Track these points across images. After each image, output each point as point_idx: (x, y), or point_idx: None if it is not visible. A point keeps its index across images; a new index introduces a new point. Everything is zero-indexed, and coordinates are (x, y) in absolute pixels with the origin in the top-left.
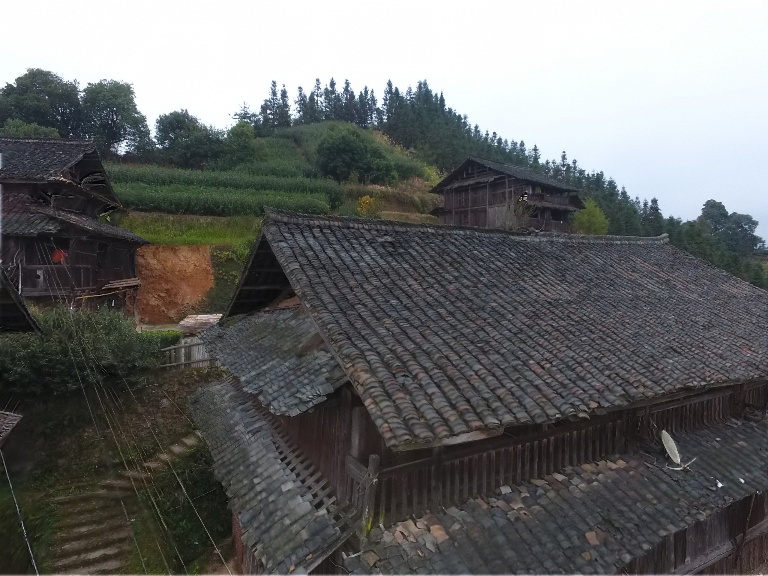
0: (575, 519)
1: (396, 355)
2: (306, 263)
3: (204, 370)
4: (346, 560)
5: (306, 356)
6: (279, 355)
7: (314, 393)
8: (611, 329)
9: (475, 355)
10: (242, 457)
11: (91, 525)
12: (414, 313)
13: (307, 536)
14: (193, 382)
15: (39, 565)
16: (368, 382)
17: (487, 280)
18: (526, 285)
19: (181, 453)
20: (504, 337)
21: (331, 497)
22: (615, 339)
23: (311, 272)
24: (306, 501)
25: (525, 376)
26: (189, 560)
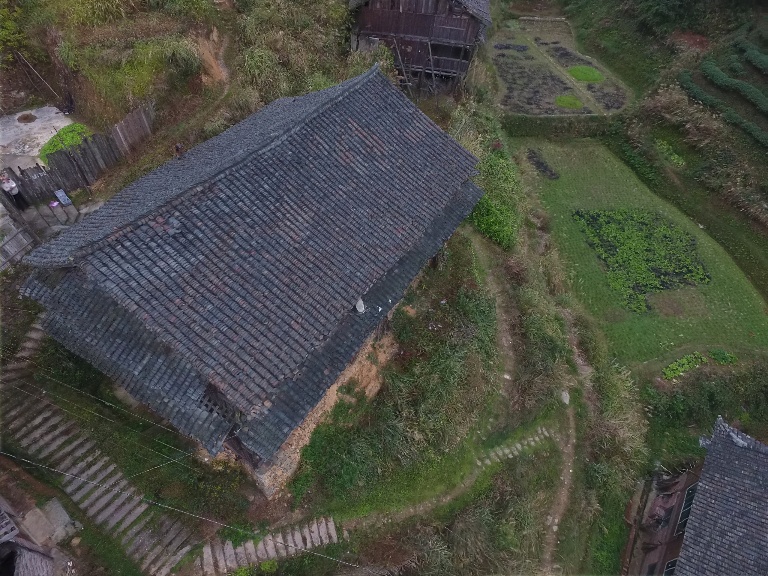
0: (320, 366)
1: (229, 360)
2: (139, 300)
3: (10, 271)
4: (237, 434)
5: (172, 356)
6: (147, 348)
7: (199, 395)
8: (331, 260)
9: (265, 335)
10: (143, 384)
11: (16, 408)
12: (224, 312)
13: (214, 428)
14: (8, 286)
15: (4, 443)
16: (225, 389)
17: (256, 244)
18: (280, 233)
19: (43, 338)
20: (276, 306)
21: (216, 406)
22: (332, 270)
23: (147, 307)
24: (204, 411)
25: (291, 335)
26: (96, 387)
